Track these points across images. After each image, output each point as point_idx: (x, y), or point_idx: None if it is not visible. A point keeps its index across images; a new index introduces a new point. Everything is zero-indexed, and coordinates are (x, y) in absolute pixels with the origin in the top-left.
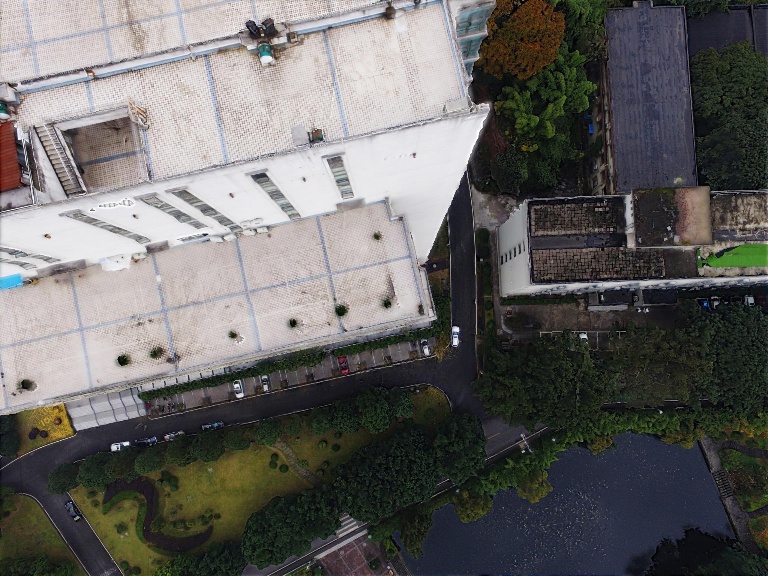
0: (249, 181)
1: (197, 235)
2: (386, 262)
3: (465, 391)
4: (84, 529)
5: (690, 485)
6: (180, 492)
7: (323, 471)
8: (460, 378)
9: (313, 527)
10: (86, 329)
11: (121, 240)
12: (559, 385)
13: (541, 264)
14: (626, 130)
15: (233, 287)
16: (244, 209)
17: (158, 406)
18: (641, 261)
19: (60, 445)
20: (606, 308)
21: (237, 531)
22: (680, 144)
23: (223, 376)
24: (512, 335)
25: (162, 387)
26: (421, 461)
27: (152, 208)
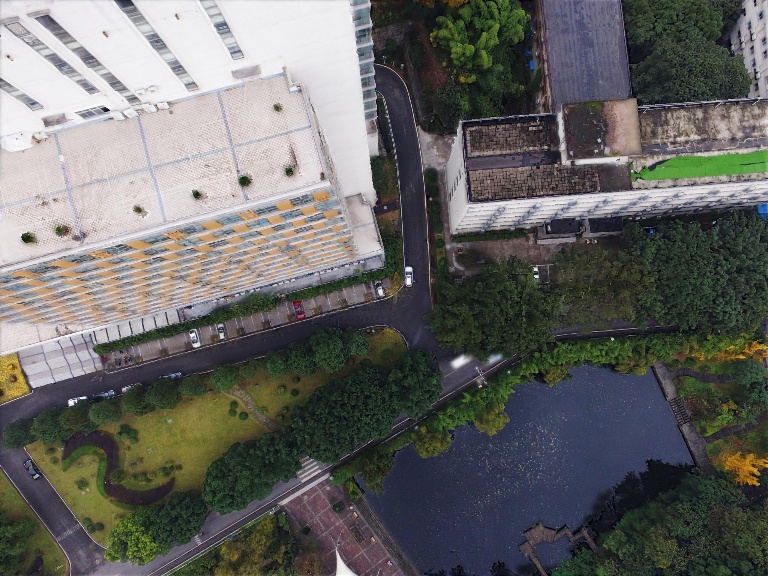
0: (117, 12)
1: (95, 109)
2: (287, 133)
3: (421, 330)
4: (44, 488)
5: (647, 414)
6: (140, 445)
7: (283, 416)
8: (416, 318)
9: (273, 469)
10: None
11: (11, 104)
12: (504, 307)
13: (478, 184)
14: (562, 59)
15: (136, 163)
16: (130, 65)
17: (114, 359)
18: (576, 177)
19: (17, 403)
20: (555, 241)
21: (199, 482)
22: (615, 70)
23: (178, 325)
24: (464, 272)
25: (117, 339)
26: (376, 396)
27: (23, 44)
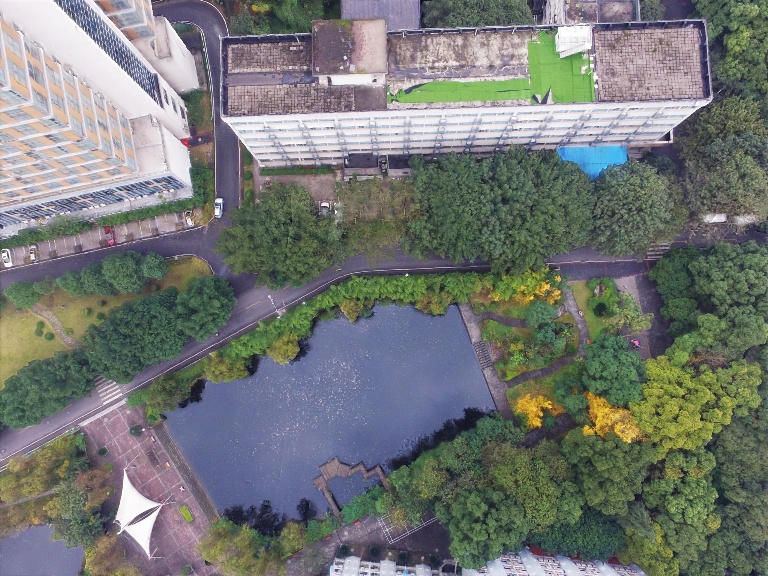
0: None
1: None
2: None
3: None
4: None
5: (451, 356)
6: None
7: None
8: None
9: (64, 386)
10: None
11: None
12: (267, 225)
13: (236, 99)
14: None
15: None
16: None
17: None
18: (332, 97)
19: None
20: (362, 178)
21: None
22: (406, 5)
23: None
24: None
25: None
26: (161, 316)
27: None
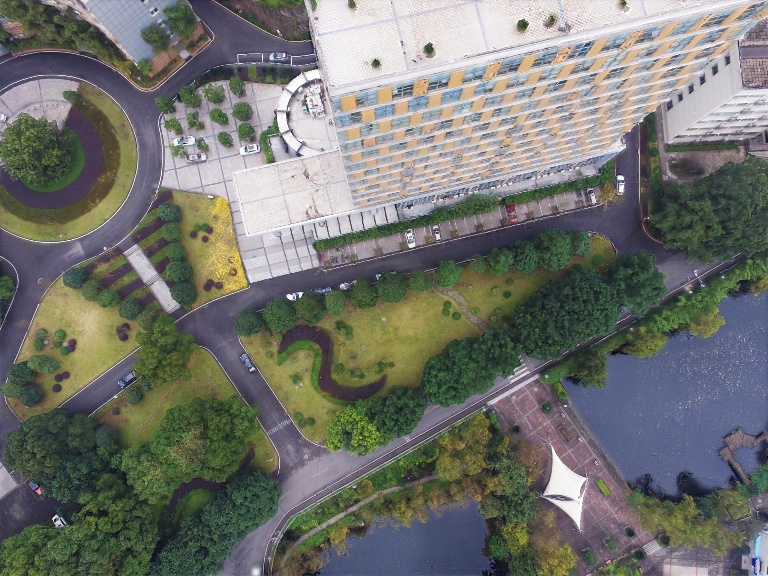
0: None
1: None
2: None
3: (630, 238)
4: (258, 382)
5: None
6: (354, 341)
7: (496, 317)
8: (625, 226)
9: (496, 364)
10: (480, 0)
11: None
12: (757, 198)
13: (749, 72)
14: None
15: None
16: None
17: (331, 257)
18: None
19: (234, 297)
20: (765, 154)
21: (410, 380)
22: None
23: (398, 224)
24: (677, 180)
25: (338, 235)
26: (606, 291)
27: None
